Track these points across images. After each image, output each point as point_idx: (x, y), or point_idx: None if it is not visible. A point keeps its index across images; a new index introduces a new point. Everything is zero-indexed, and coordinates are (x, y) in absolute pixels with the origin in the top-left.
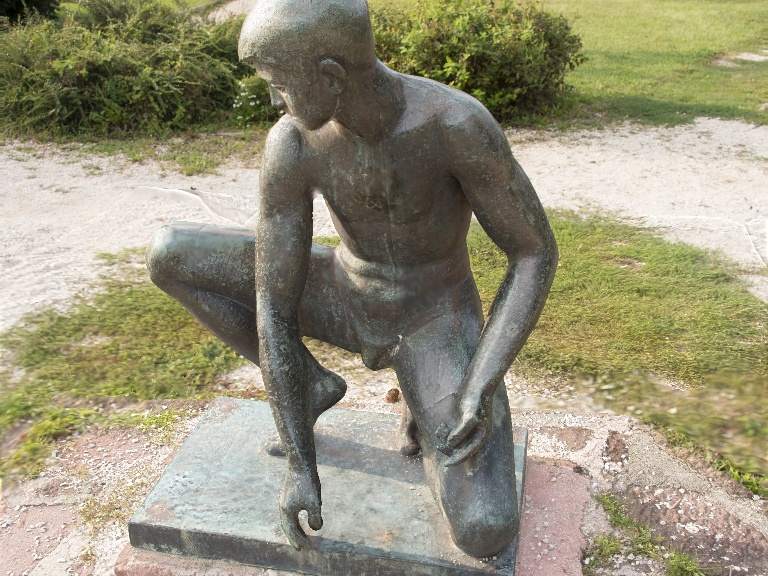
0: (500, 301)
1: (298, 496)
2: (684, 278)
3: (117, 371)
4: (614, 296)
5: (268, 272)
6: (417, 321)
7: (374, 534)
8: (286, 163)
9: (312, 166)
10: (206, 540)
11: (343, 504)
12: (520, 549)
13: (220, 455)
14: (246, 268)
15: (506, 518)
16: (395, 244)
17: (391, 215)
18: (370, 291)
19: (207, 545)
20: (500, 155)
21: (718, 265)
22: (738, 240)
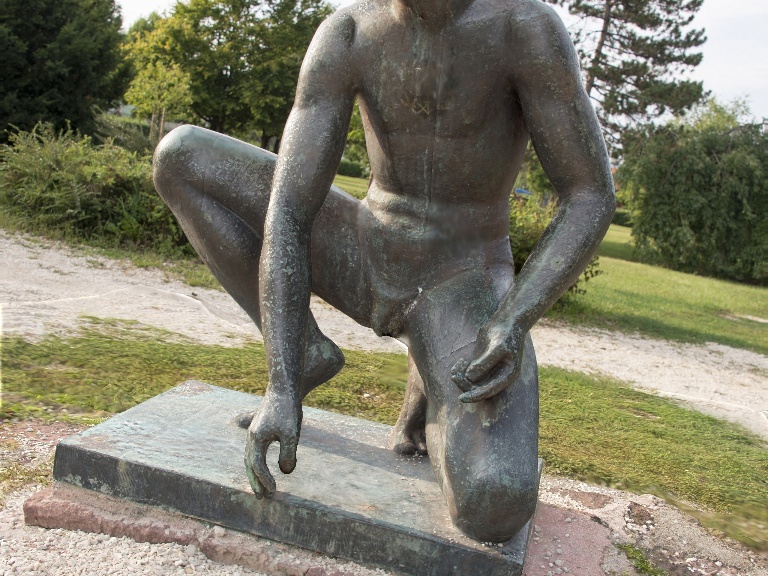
0: (546, 236)
1: (273, 419)
2: (702, 433)
3: (77, 388)
4: (628, 432)
5: (290, 166)
6: (442, 273)
7: (353, 503)
8: (334, 49)
9: (362, 57)
10: (147, 476)
11: (319, 475)
12: (527, 565)
13: (182, 417)
14: (262, 184)
15: (524, 483)
16: (435, 165)
17: (438, 124)
18: (396, 228)
19: (146, 484)
20: (569, 65)
21: (738, 433)
22: (757, 421)
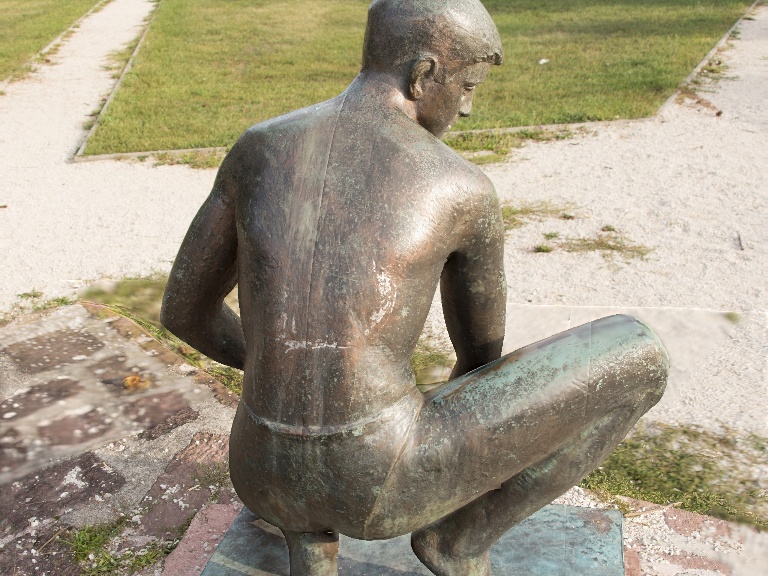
0: None
1: None
2: None
3: None
4: None
5: None
6: None
7: None
8: None
9: None
10: None
11: None
12: None
13: None
14: None
15: None
16: None
17: None
18: None
19: None
20: None
21: None
22: None
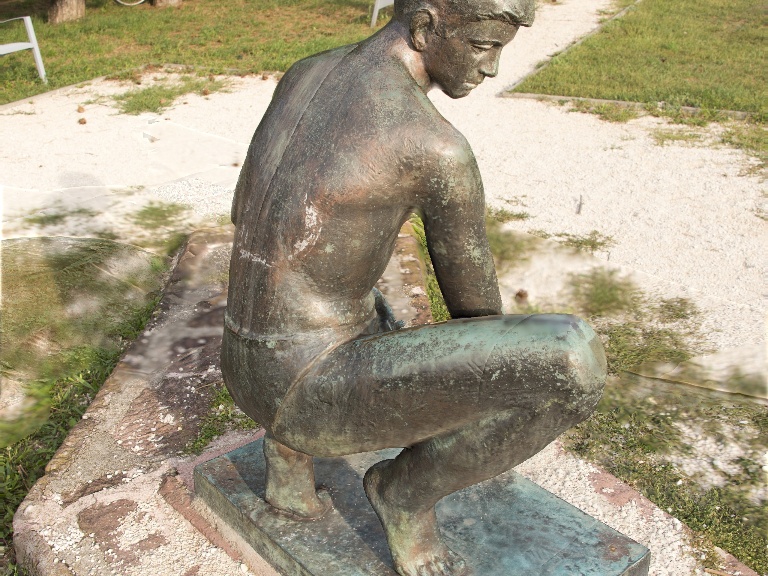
0: None
1: None
2: None
3: None
4: None
5: None
6: None
7: None
8: None
9: None
10: None
11: None
12: None
13: None
14: None
15: None
16: None
17: None
18: None
19: None
20: None
21: None
22: None
